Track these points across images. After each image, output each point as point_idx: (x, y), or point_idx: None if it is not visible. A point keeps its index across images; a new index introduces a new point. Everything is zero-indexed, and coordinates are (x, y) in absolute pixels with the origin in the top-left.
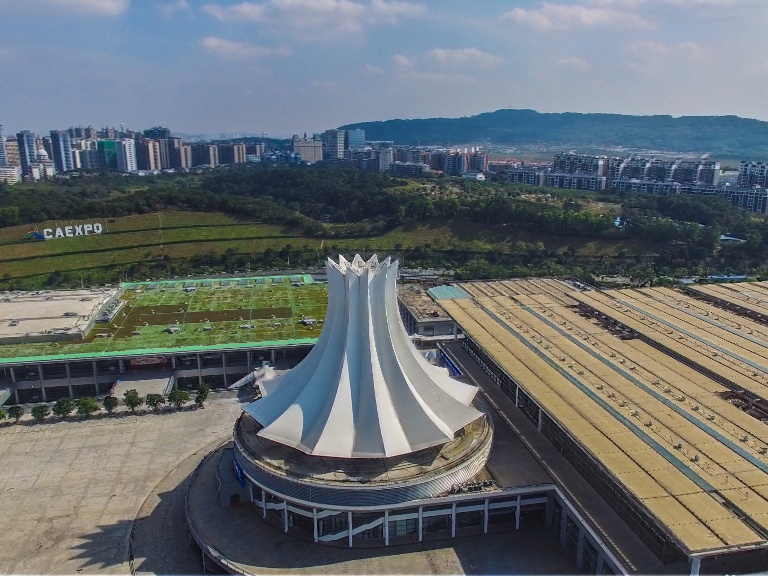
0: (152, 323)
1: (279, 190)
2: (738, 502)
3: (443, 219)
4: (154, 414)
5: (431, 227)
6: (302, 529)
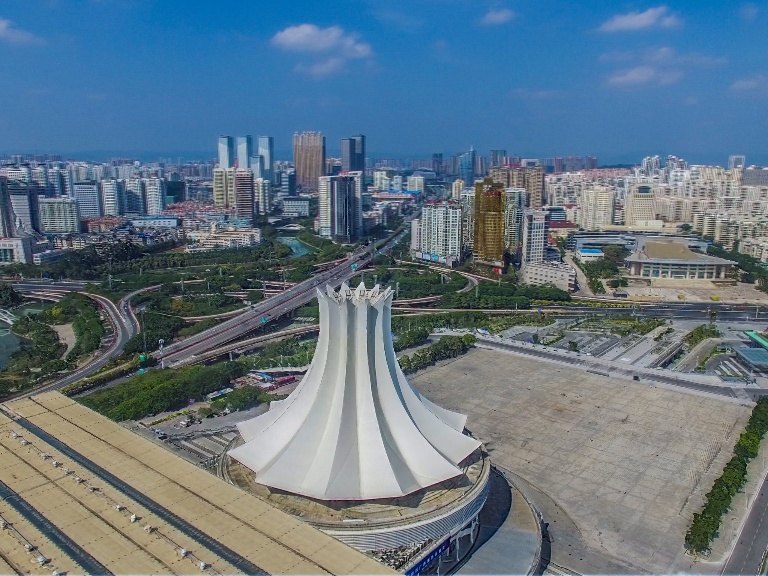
0: None
1: None
2: (4, 418)
3: None
4: None
5: None
6: None
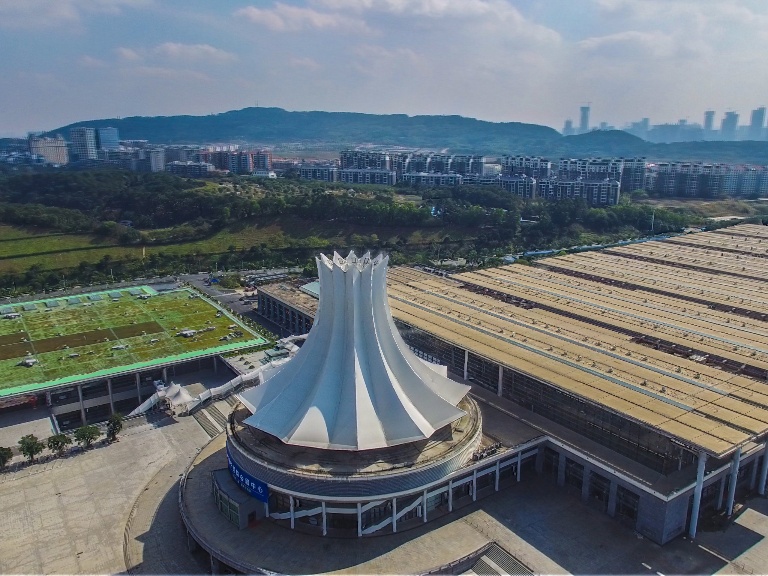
0: None
1: (50, 197)
2: (715, 414)
3: (270, 218)
4: (61, 458)
5: (259, 227)
6: (338, 529)
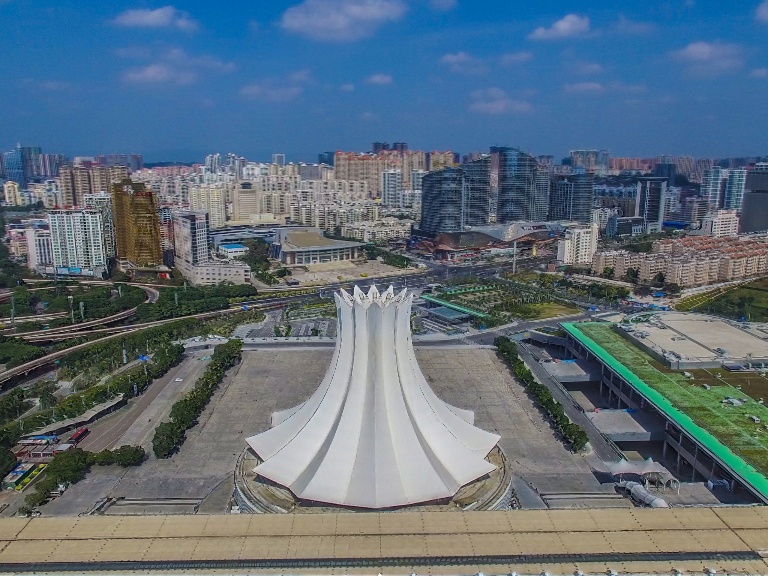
0: (747, 390)
1: None
2: None
3: None
4: (555, 432)
5: None
6: None
